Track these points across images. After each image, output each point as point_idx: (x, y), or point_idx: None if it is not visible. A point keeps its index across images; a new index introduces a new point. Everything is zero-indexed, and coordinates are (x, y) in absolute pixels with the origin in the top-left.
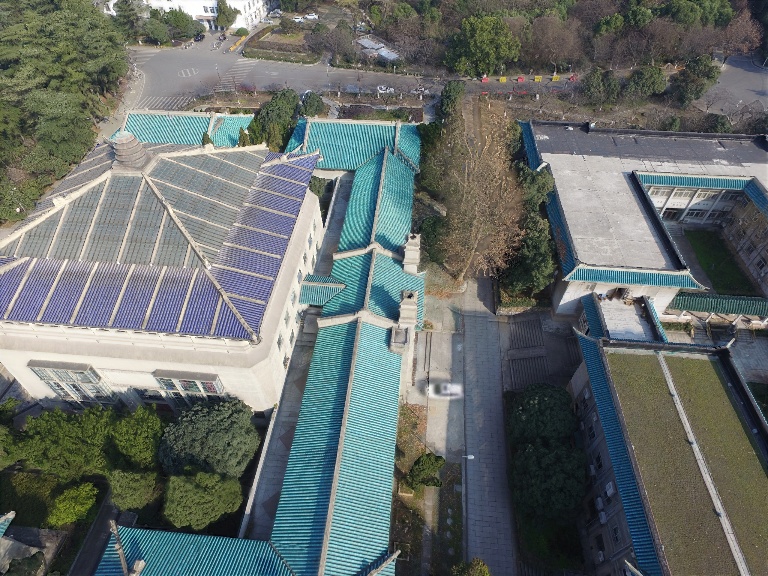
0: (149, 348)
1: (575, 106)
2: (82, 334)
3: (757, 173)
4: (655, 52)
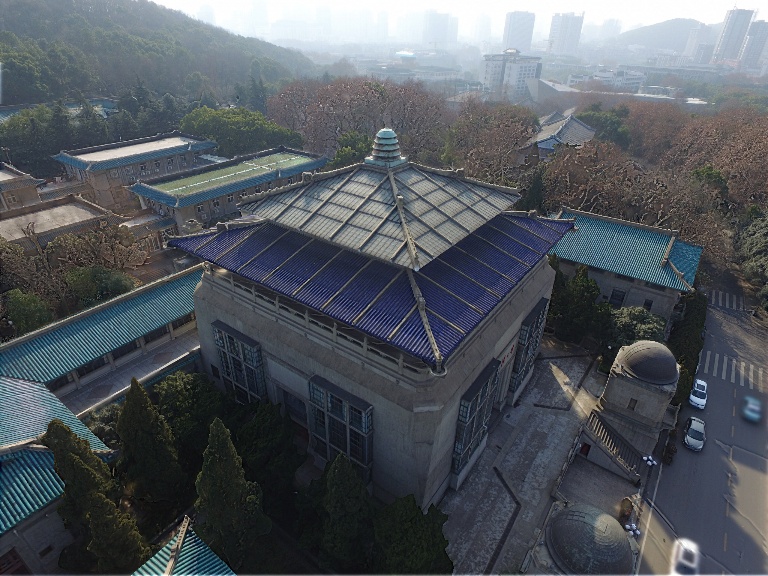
0: None
1: None
2: None
3: None
4: None
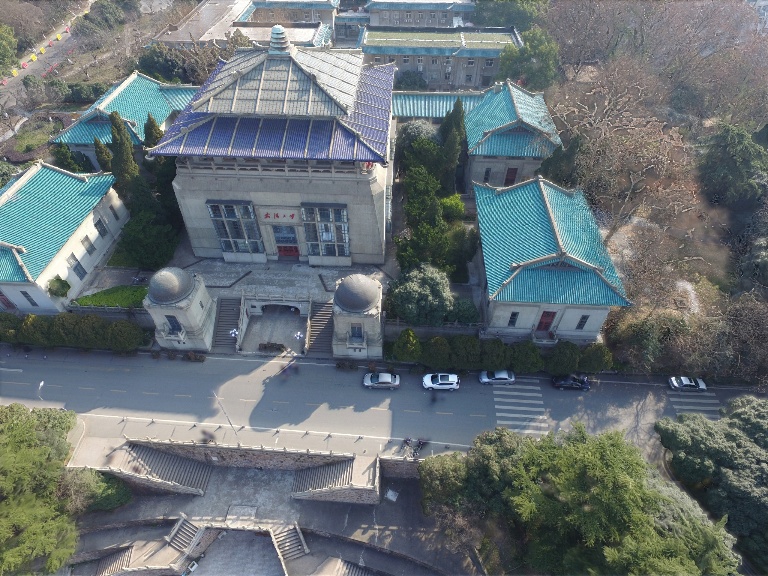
0: None
1: (103, 48)
2: None
3: (245, 2)
4: (62, 1)
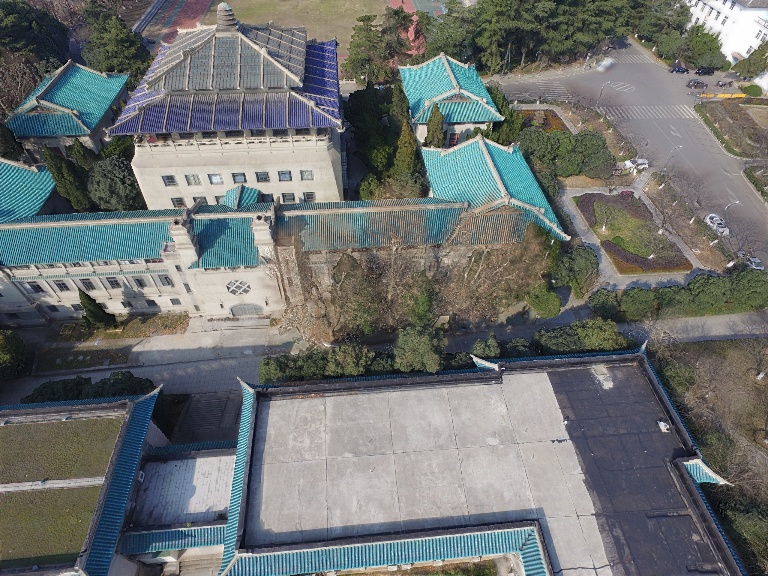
0: None
1: None
2: None
3: None
4: None
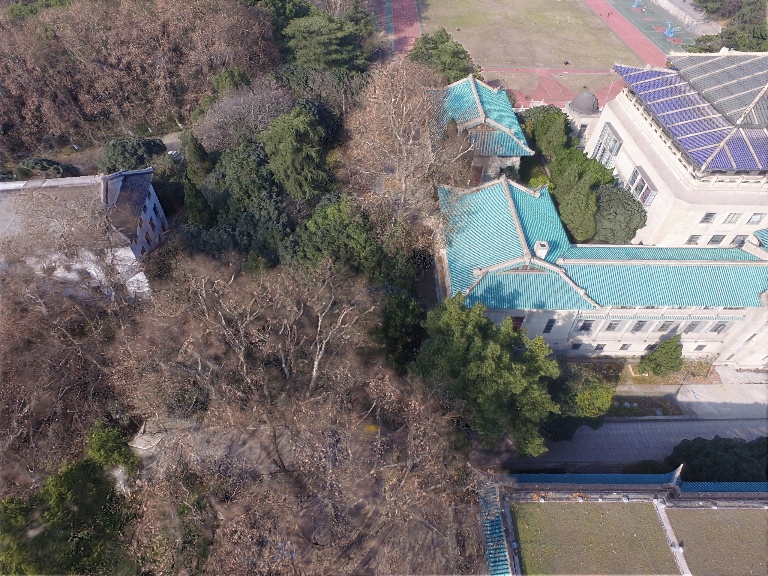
0: (654, 150)
1: None
2: (641, 122)
3: None
4: None
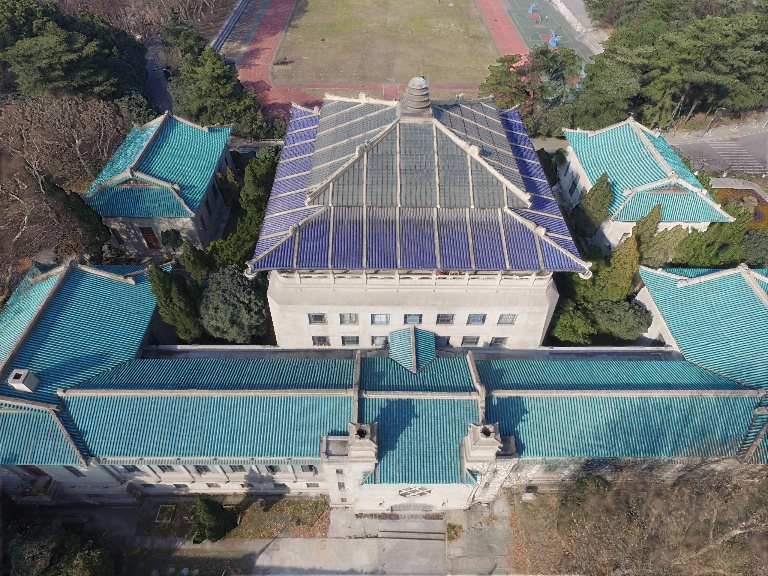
0: None
1: None
2: None
3: None
4: None
